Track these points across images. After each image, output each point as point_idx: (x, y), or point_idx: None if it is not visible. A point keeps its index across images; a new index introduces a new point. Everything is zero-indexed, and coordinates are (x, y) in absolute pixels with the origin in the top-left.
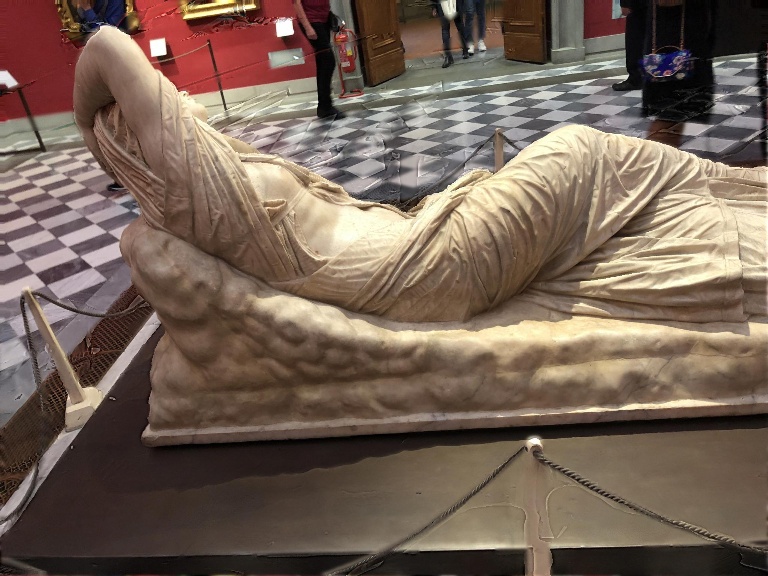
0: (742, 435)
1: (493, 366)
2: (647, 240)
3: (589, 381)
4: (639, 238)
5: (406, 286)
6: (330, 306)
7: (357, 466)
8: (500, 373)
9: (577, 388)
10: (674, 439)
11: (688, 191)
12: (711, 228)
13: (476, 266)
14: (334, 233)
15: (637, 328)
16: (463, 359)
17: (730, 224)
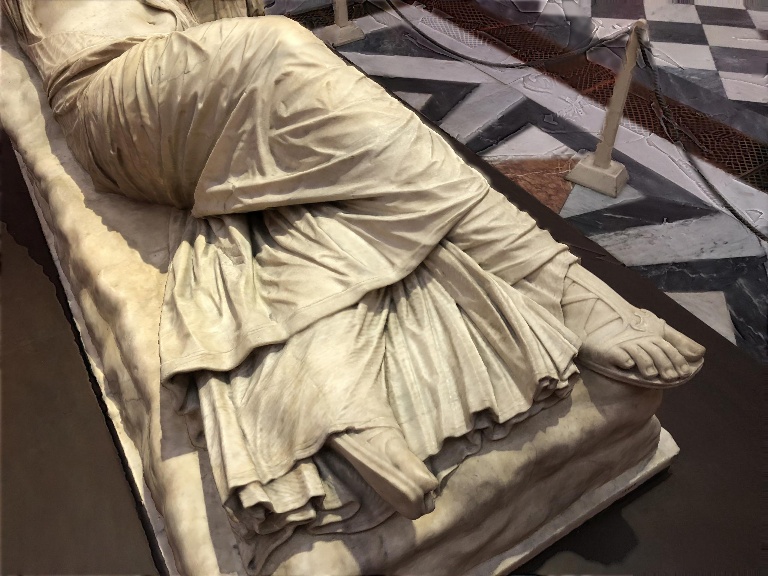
0: (137, 546)
1: (68, 250)
2: (238, 251)
3: (101, 342)
4: (235, 241)
5: (56, 110)
6: (36, 89)
7: (15, 246)
8: (69, 262)
9: (94, 338)
10: (111, 474)
11: (367, 237)
12: (283, 304)
13: (87, 133)
14: (64, 14)
15: (145, 336)
16: (56, 221)
17: (295, 320)
